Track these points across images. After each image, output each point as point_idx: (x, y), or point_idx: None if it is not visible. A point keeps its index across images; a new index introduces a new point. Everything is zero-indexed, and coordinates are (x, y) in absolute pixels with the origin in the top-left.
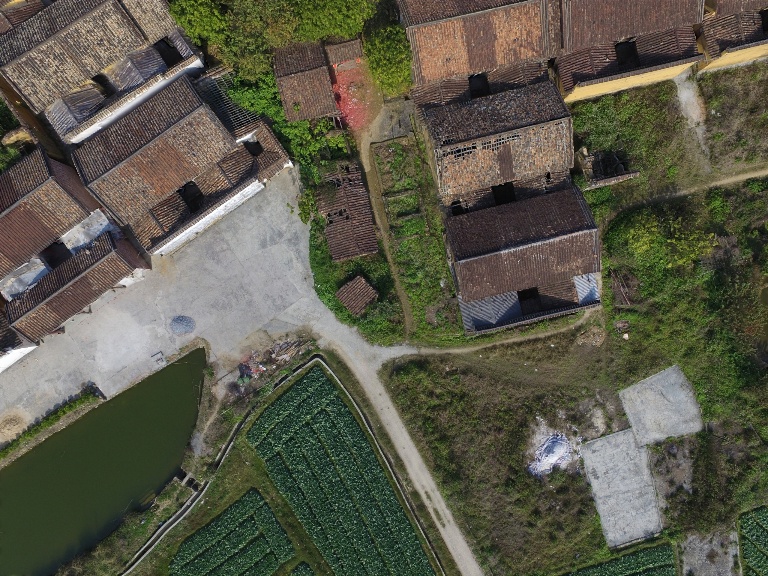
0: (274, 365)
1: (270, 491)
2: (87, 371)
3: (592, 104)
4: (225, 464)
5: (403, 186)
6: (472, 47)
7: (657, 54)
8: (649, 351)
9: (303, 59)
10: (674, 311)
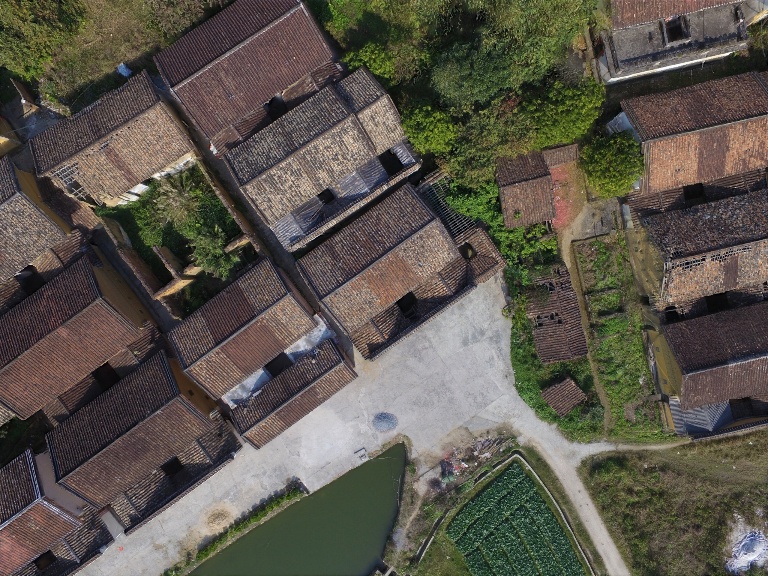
0: (476, 462)
1: None
2: (292, 466)
3: None
4: (426, 558)
5: (606, 285)
6: (703, 158)
7: None
8: None
9: (524, 166)
10: None
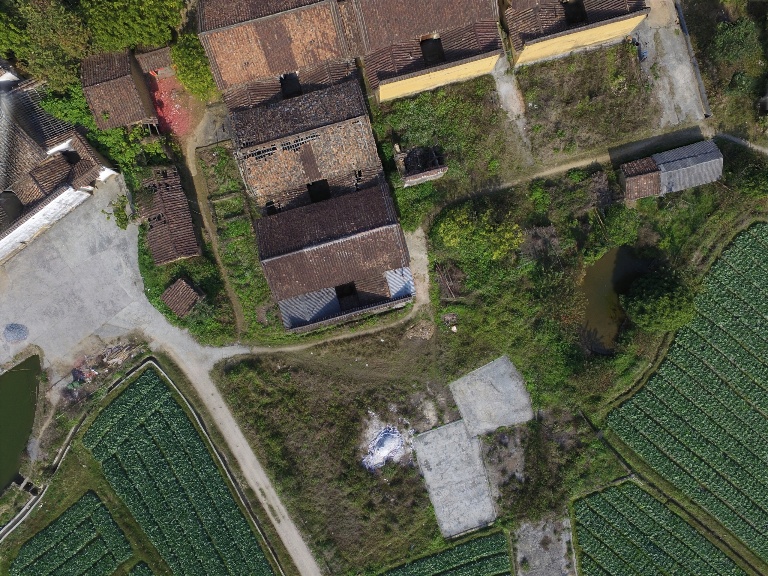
0: (106, 369)
1: (108, 493)
2: None
3: (410, 101)
4: (62, 468)
5: (228, 189)
6: (269, 50)
7: (460, 50)
8: (477, 343)
9: (110, 68)
10: (499, 302)
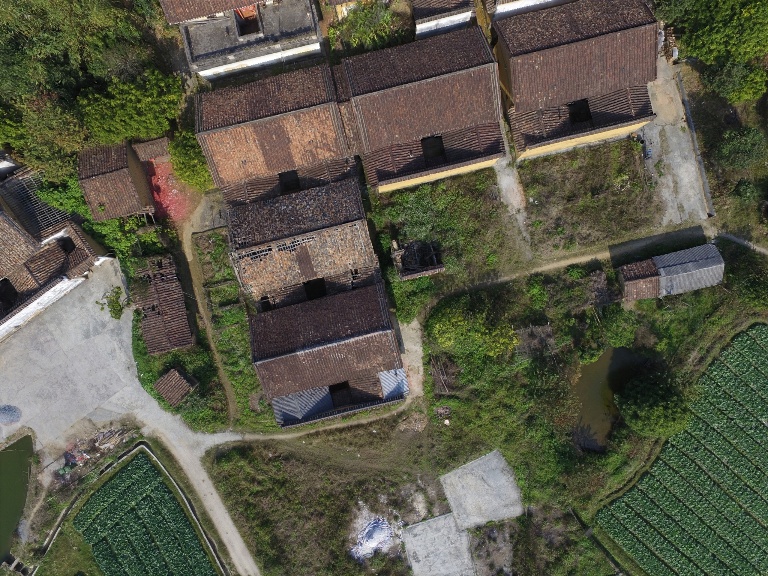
0: (98, 453)
1: (97, 575)
2: None
3: (409, 193)
4: (53, 549)
5: (223, 276)
6: (266, 150)
7: (461, 150)
8: (470, 437)
9: (106, 160)
10: (493, 398)
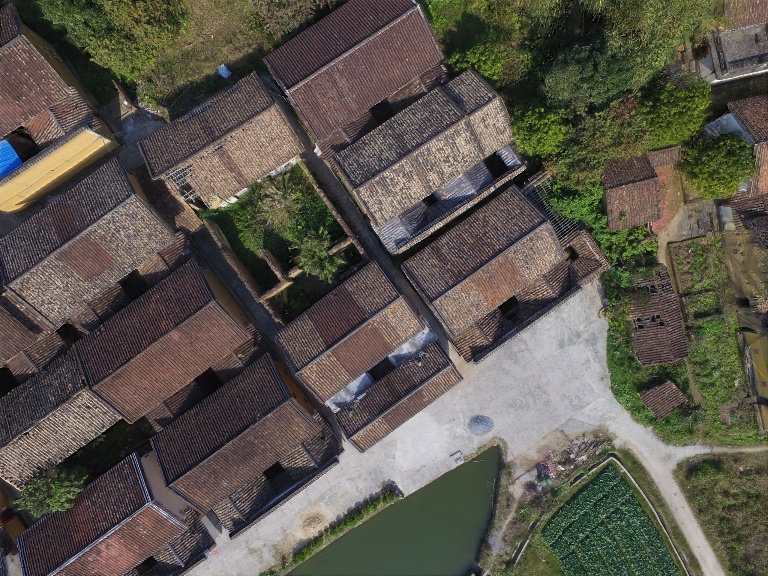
0: (572, 465)
1: None
2: (387, 470)
3: None
4: (521, 561)
5: (702, 287)
6: None
7: None
8: None
9: (630, 168)
10: None
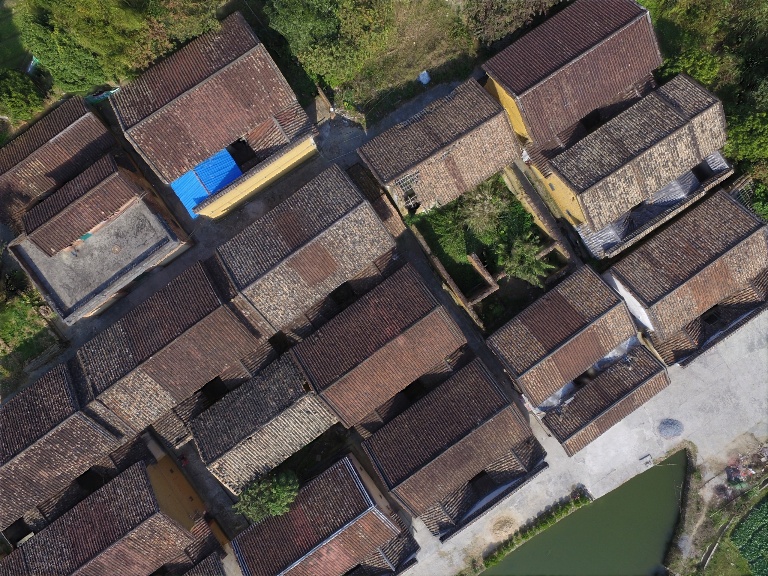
0: (763, 469)
1: None
2: (577, 473)
3: None
4: (711, 565)
5: None
6: None
7: None
8: None
9: None
10: None
